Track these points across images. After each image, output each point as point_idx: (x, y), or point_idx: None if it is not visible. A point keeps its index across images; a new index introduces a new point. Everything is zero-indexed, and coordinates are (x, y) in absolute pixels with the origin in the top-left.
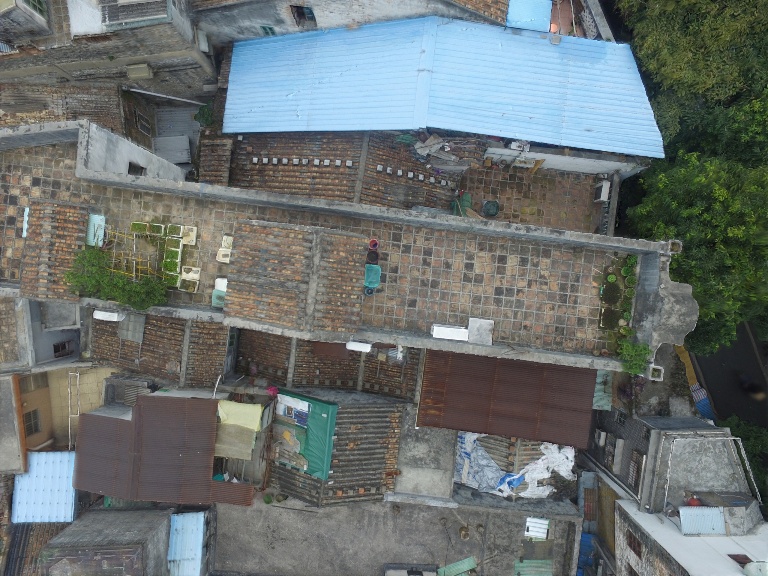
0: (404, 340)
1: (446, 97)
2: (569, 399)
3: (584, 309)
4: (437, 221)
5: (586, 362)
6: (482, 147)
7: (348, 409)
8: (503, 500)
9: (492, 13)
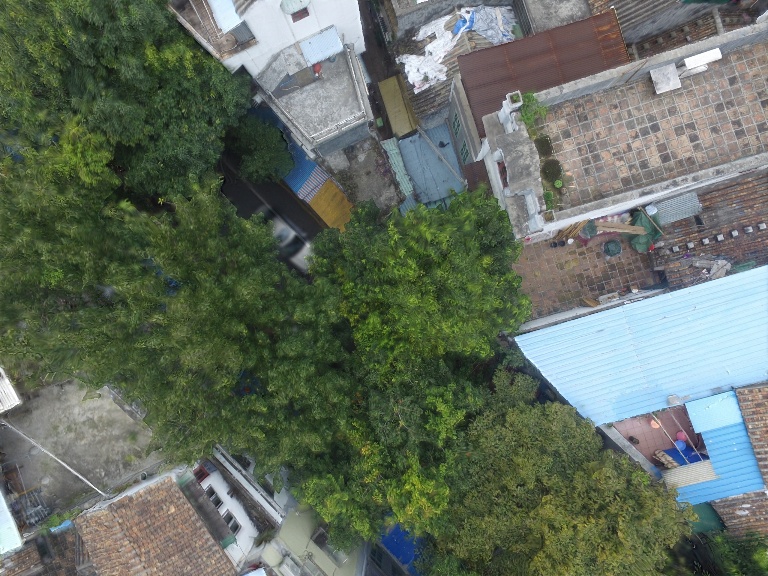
0: (745, 33)
1: (762, 300)
2: (491, 93)
3: (569, 147)
4: (766, 154)
5: (567, 89)
6: (674, 285)
7: (667, 5)
8: (466, 3)
9: (760, 393)
